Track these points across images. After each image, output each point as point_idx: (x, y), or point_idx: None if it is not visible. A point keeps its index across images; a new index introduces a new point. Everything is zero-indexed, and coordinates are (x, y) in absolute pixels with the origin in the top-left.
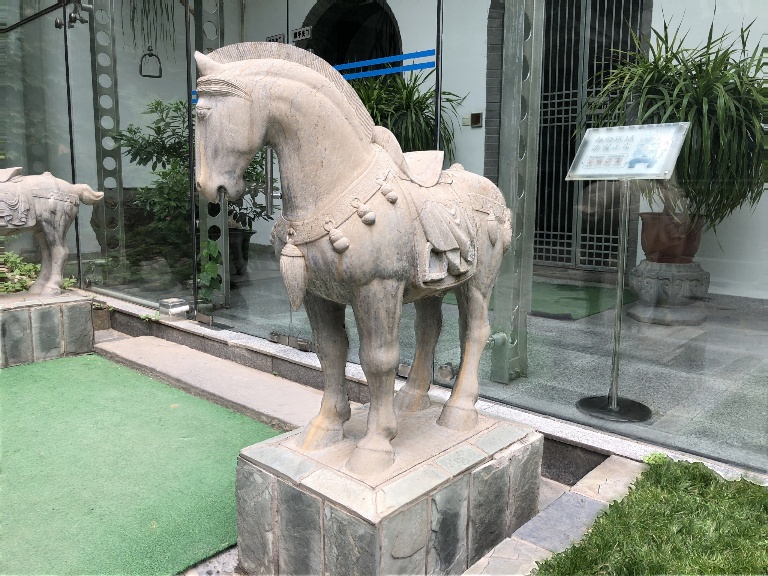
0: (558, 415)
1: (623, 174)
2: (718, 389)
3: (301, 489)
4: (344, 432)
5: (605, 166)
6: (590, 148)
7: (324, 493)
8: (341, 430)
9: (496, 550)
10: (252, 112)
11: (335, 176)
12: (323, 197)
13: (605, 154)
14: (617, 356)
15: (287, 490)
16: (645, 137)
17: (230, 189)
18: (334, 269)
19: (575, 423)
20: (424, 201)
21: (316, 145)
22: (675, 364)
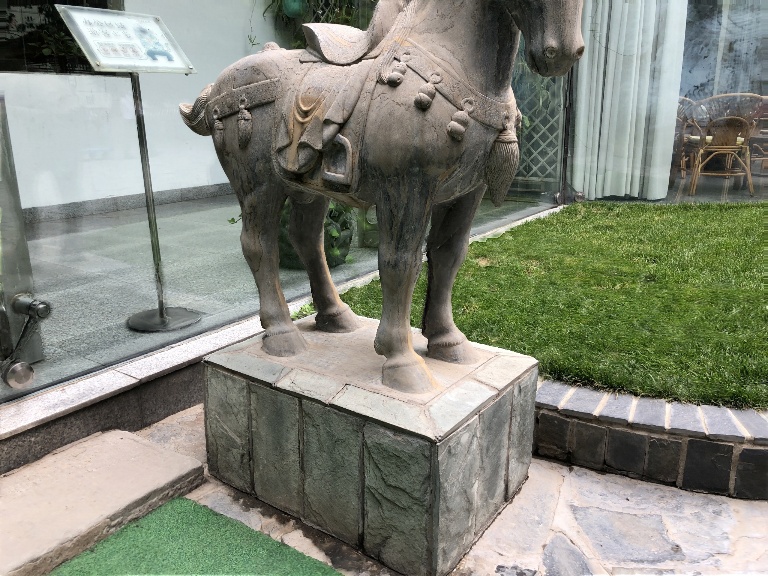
0: (173, 340)
1: (152, 66)
2: (126, 285)
3: (500, 396)
4: None
5: (125, 56)
6: (88, 31)
7: (514, 377)
8: None
9: None
10: None
11: None
12: None
13: (112, 41)
14: None
15: (490, 412)
16: (135, 26)
17: None
18: None
19: (194, 337)
20: None
21: None
22: (36, 289)
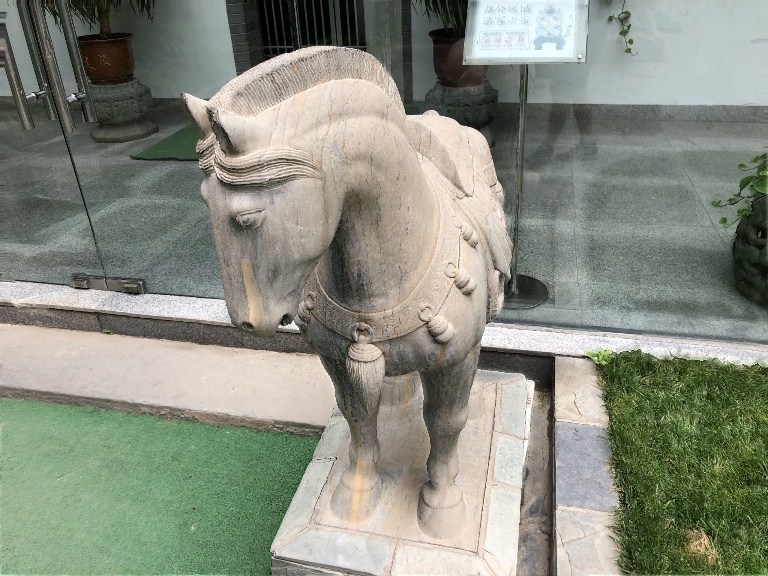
0: None
1: (530, 58)
2: (568, 235)
3: None
4: None
5: (505, 46)
6: (481, 21)
7: None
8: (379, 478)
9: (561, 533)
10: (326, 195)
11: (420, 241)
12: (409, 275)
13: (501, 30)
14: (516, 243)
15: None
16: (543, 7)
17: (293, 312)
18: (432, 362)
19: (496, 323)
20: (486, 220)
21: (399, 208)
22: None
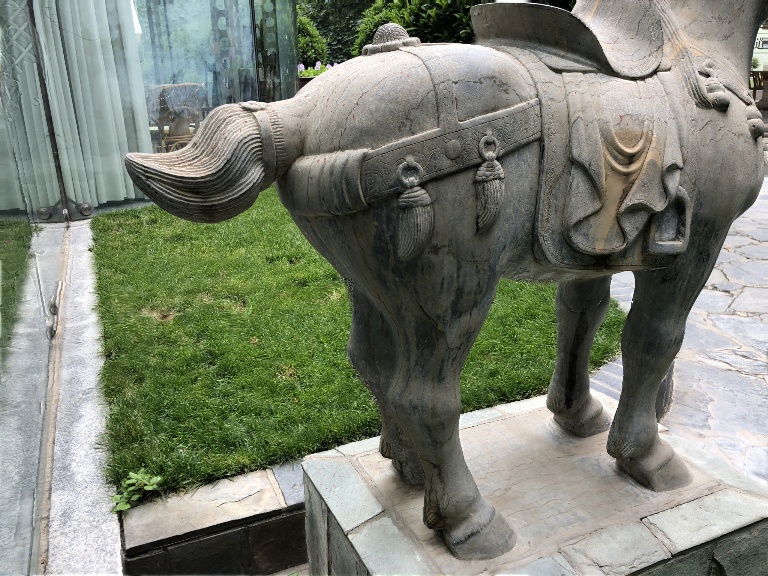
0: None
1: None
2: None
3: None
4: (615, 479)
5: None
6: None
7: None
8: None
9: None
10: None
11: None
12: None
13: None
14: None
15: None
16: None
17: None
18: None
19: None
20: None
21: None
22: None
